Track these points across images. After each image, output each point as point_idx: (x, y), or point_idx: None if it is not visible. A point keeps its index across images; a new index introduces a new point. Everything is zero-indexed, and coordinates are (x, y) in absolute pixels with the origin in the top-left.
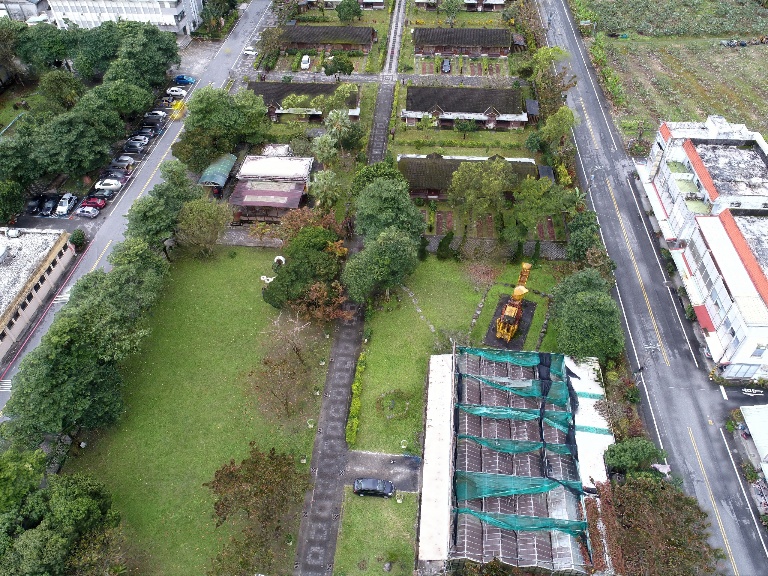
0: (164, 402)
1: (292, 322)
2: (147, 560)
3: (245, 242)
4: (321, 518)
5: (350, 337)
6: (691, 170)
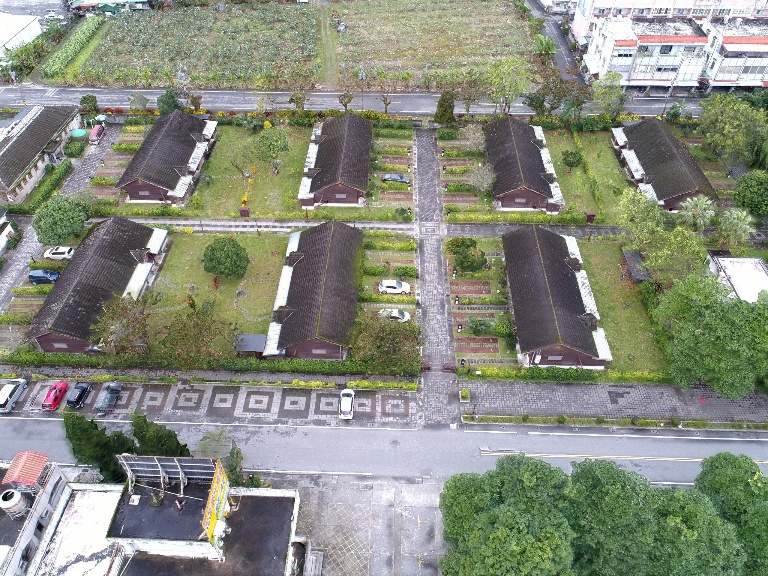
0: None
1: None
2: None
3: None
4: None
5: None
6: (651, 50)
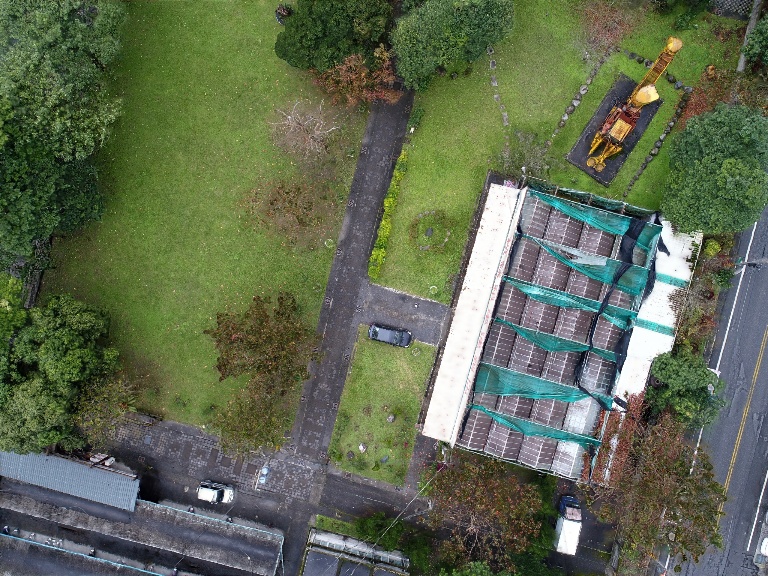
0: (154, 180)
1: (316, 77)
2: (157, 369)
3: None
4: (331, 356)
5: (392, 115)
6: None
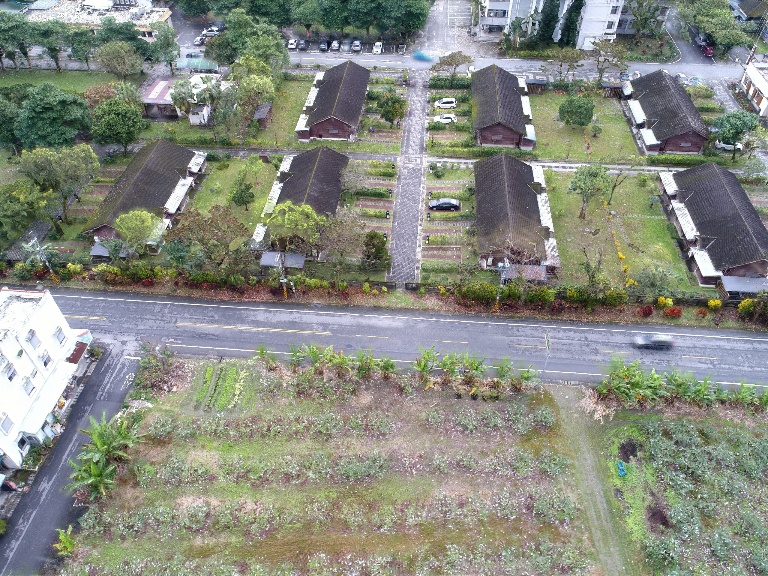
0: None
1: None
2: None
3: None
4: None
5: None
6: None
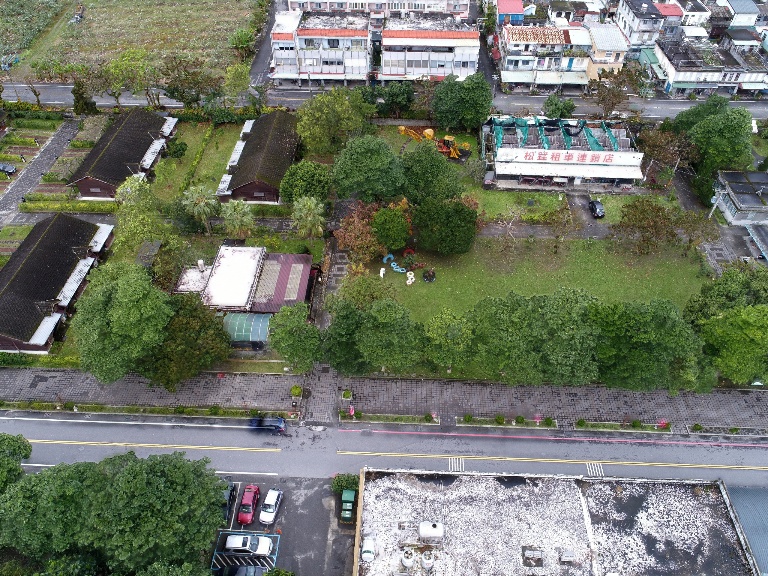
0: None
1: (462, 259)
2: None
3: None
4: None
5: None
6: (318, 43)
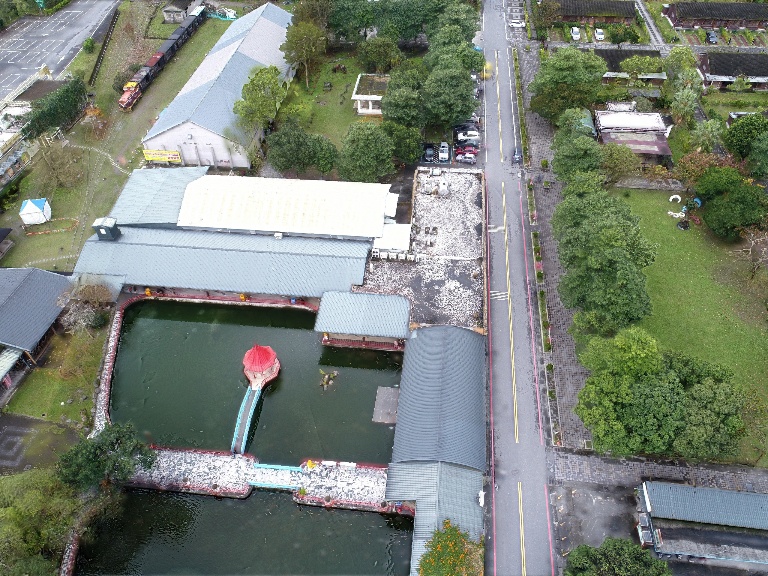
0: None
1: (720, 249)
2: None
3: (626, 185)
4: None
5: None
6: None
